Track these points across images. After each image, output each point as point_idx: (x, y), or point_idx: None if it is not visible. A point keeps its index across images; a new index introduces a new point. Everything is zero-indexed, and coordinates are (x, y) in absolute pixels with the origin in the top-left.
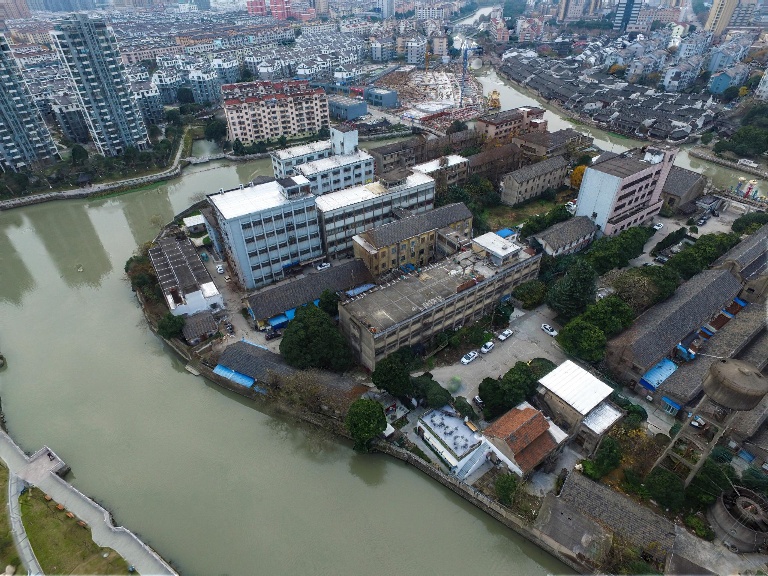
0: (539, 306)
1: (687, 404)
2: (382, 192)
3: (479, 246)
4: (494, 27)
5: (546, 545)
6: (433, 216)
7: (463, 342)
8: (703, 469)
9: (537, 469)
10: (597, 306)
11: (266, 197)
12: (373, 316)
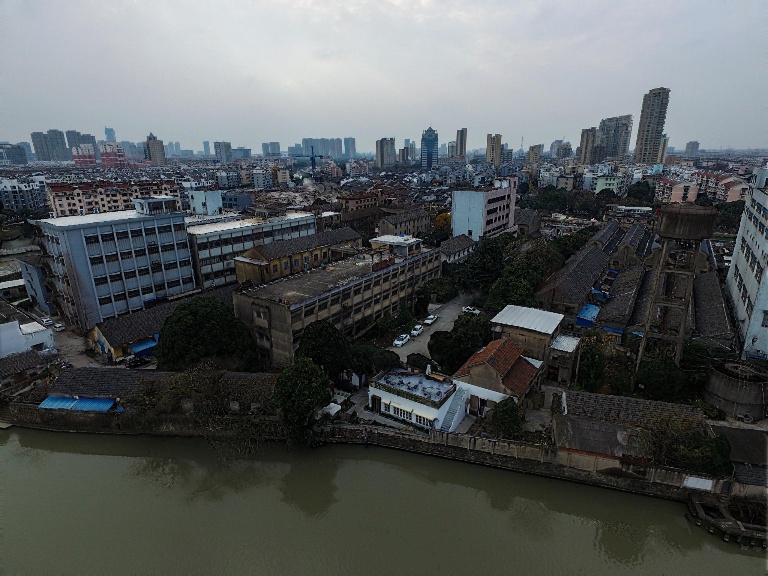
0: (451, 299)
1: (627, 324)
2: (261, 222)
3: (380, 242)
4: (327, 167)
5: (579, 471)
6: (322, 235)
7: (389, 331)
8: (683, 348)
9: (529, 397)
10: (512, 265)
11: (118, 215)
12: (282, 296)
